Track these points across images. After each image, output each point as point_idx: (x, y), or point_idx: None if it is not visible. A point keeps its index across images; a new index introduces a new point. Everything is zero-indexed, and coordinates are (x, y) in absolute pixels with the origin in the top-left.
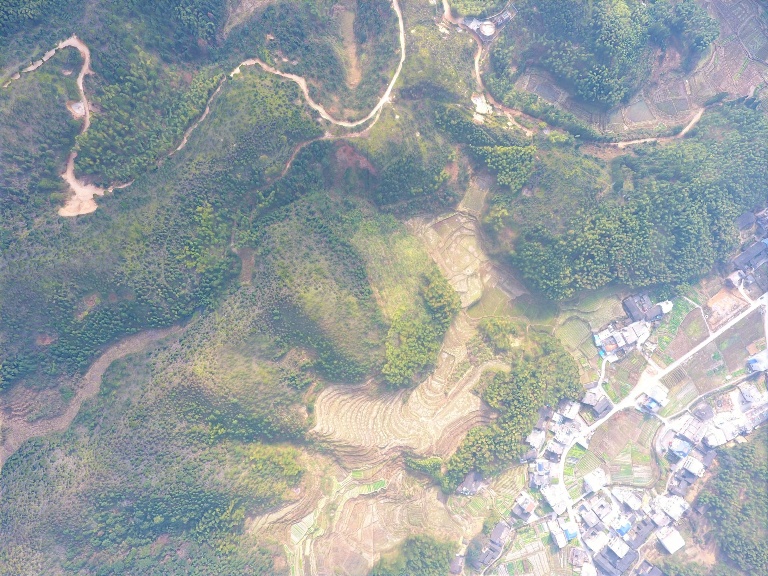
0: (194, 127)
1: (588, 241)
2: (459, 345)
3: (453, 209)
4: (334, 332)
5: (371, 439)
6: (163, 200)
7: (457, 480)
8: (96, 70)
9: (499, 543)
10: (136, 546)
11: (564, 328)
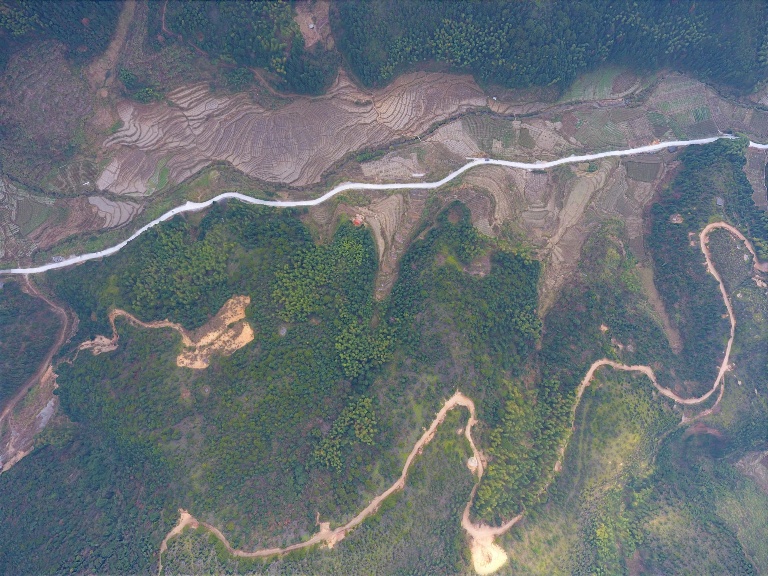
0: None
1: None
2: None
3: None
4: None
5: None
6: (571, 537)
7: None
8: (479, 418)
9: None
10: None
11: None
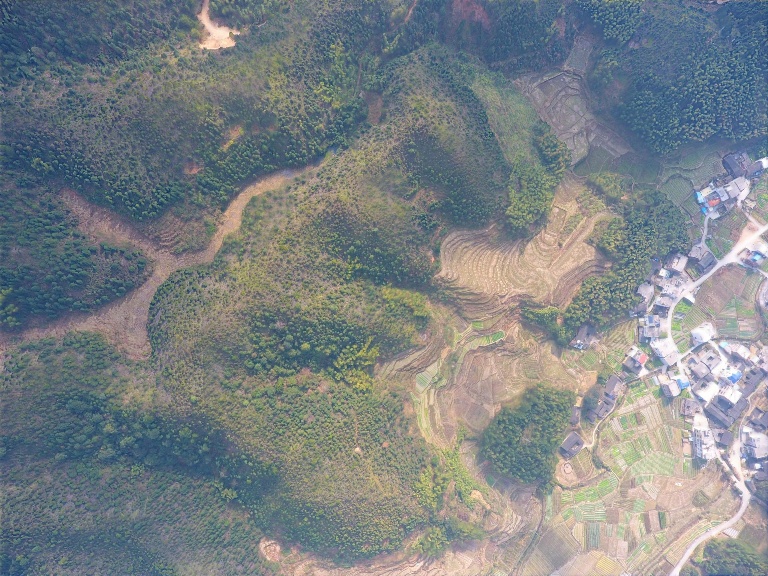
0: None
1: (698, 87)
2: (569, 201)
3: (559, 68)
4: (466, 166)
5: (492, 287)
6: (300, 34)
7: (572, 331)
8: None
9: (613, 396)
10: (282, 376)
11: (667, 186)
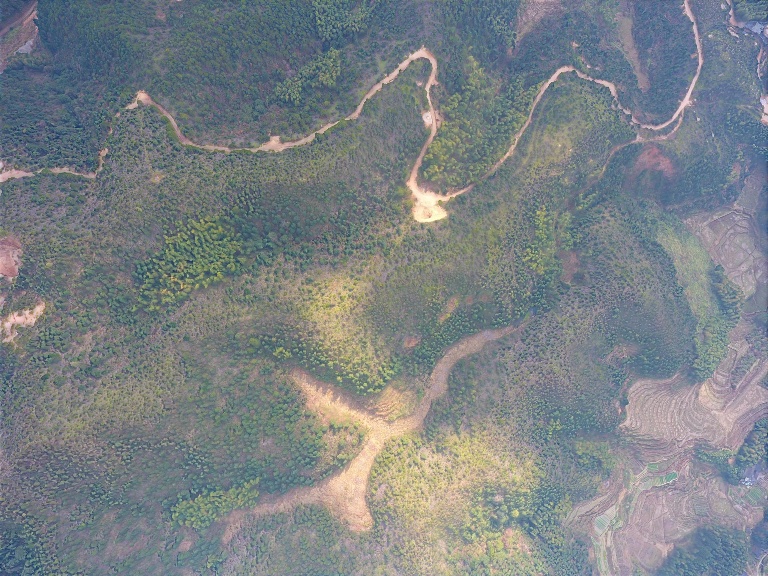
0: (519, 133)
1: None
2: (738, 340)
3: (729, 208)
4: (666, 329)
5: (670, 432)
6: (511, 205)
7: (743, 471)
8: (440, 80)
9: None
10: (490, 540)
11: None
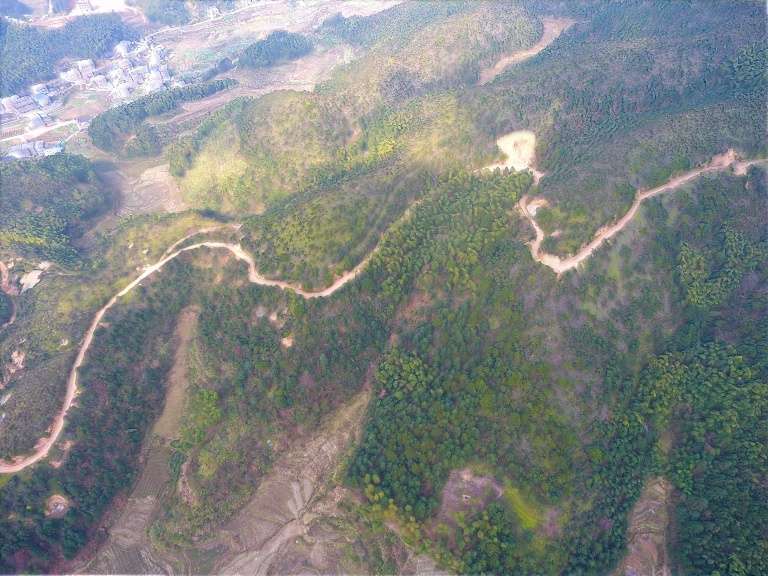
0: None
1: None
2: None
3: None
4: None
5: None
6: (425, 143)
7: None
8: None
9: None
10: None
11: None
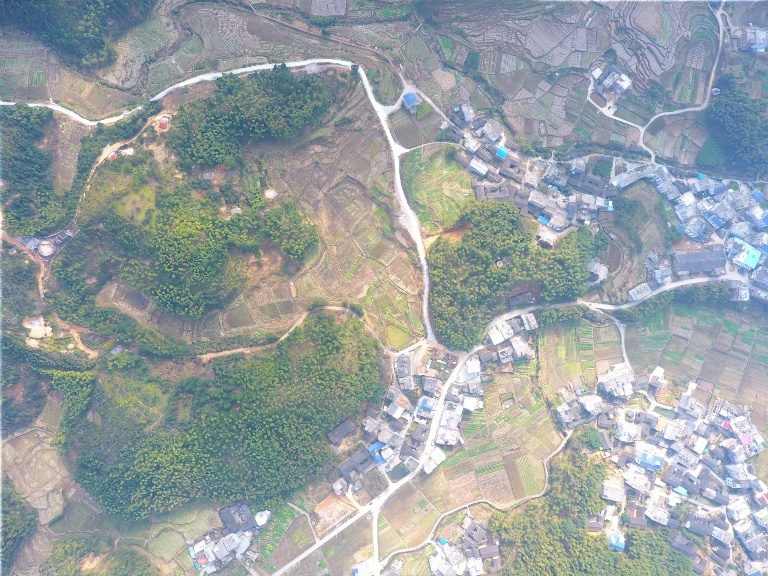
0: None
1: (141, 473)
2: (34, 566)
3: (29, 425)
4: None
5: None
6: None
7: None
8: None
9: None
10: None
11: (158, 540)
